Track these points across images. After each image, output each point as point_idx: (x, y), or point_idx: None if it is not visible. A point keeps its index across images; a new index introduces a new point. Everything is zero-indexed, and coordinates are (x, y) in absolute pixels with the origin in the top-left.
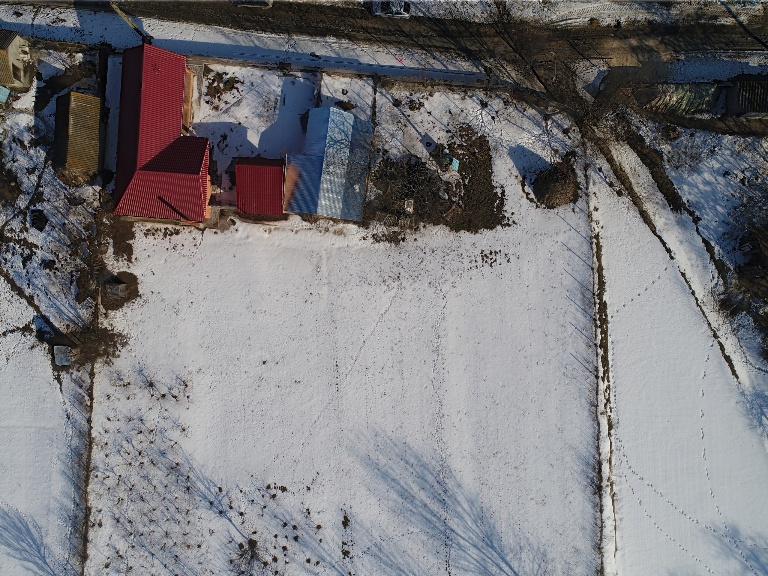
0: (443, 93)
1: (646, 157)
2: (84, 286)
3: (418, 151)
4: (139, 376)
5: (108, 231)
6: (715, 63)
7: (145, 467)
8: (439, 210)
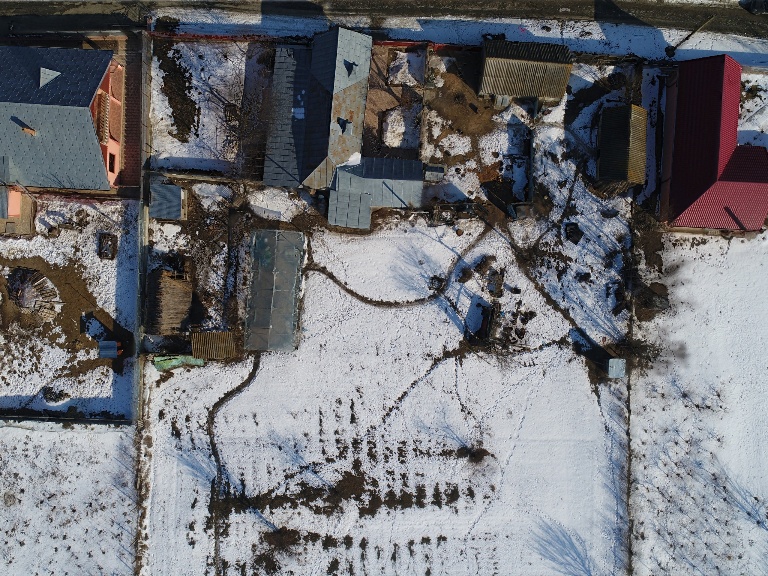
0: None
1: None
2: (624, 298)
3: None
4: (673, 387)
5: (639, 242)
6: None
7: (684, 478)
8: None
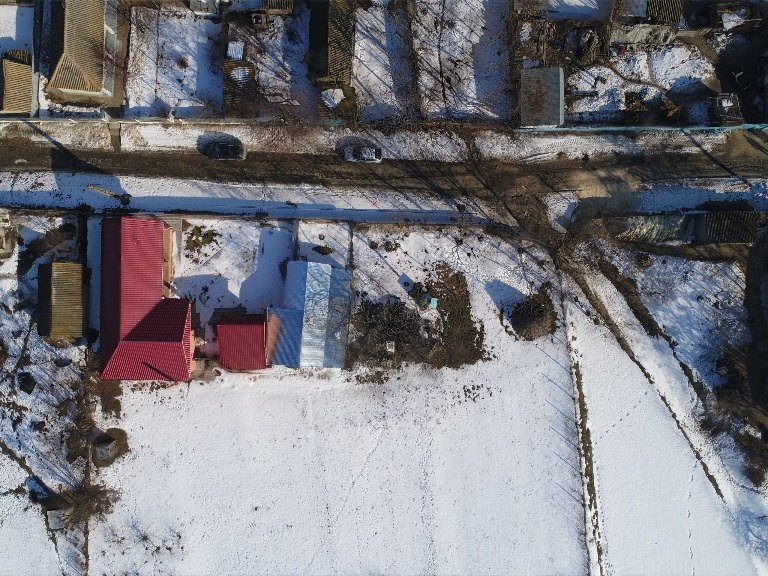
0: (418, 233)
1: (620, 285)
2: (74, 446)
3: (397, 291)
4: (133, 530)
5: (95, 389)
6: (682, 191)
7: None
8: (420, 351)
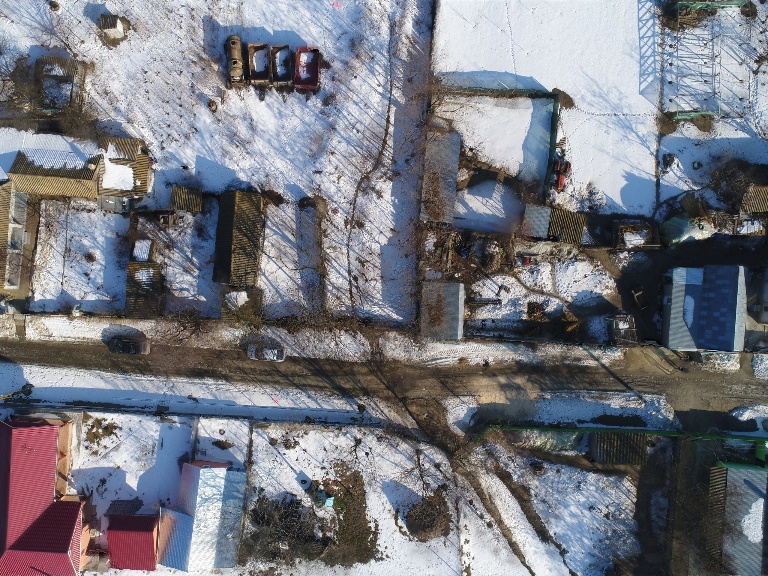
0: (318, 431)
1: (515, 491)
2: None
3: (294, 488)
4: None
5: None
6: (579, 403)
7: None
8: (311, 553)
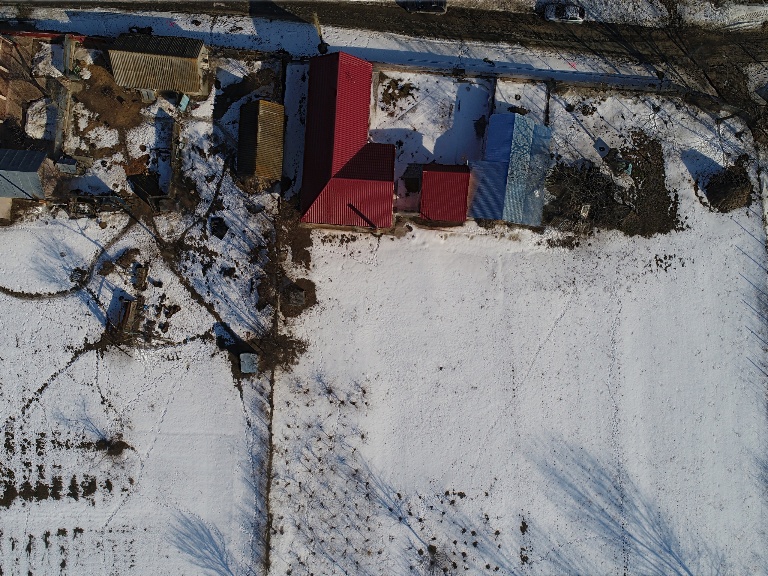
0: (616, 98)
1: None
2: (265, 293)
3: (591, 156)
4: (318, 383)
5: (286, 238)
6: None
7: (325, 474)
8: (617, 215)
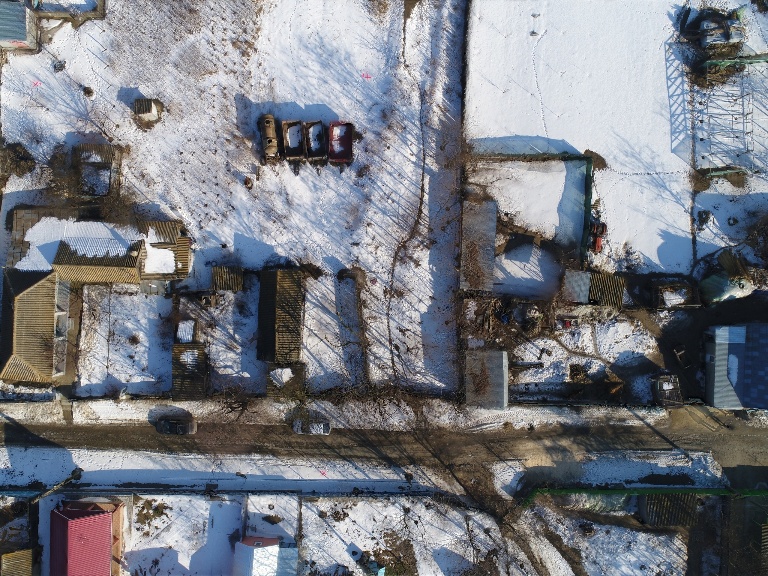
0: (366, 502)
1: (565, 554)
2: None
3: (345, 560)
4: None
5: None
6: (626, 464)
7: None
8: None
